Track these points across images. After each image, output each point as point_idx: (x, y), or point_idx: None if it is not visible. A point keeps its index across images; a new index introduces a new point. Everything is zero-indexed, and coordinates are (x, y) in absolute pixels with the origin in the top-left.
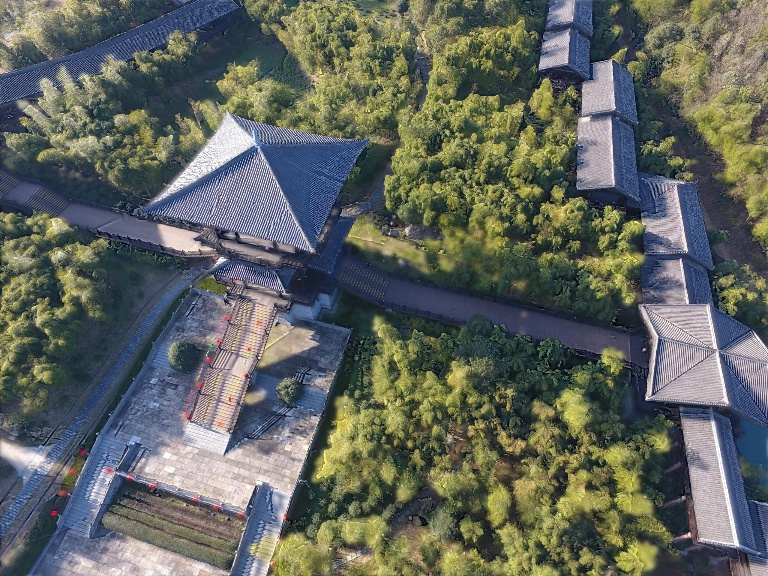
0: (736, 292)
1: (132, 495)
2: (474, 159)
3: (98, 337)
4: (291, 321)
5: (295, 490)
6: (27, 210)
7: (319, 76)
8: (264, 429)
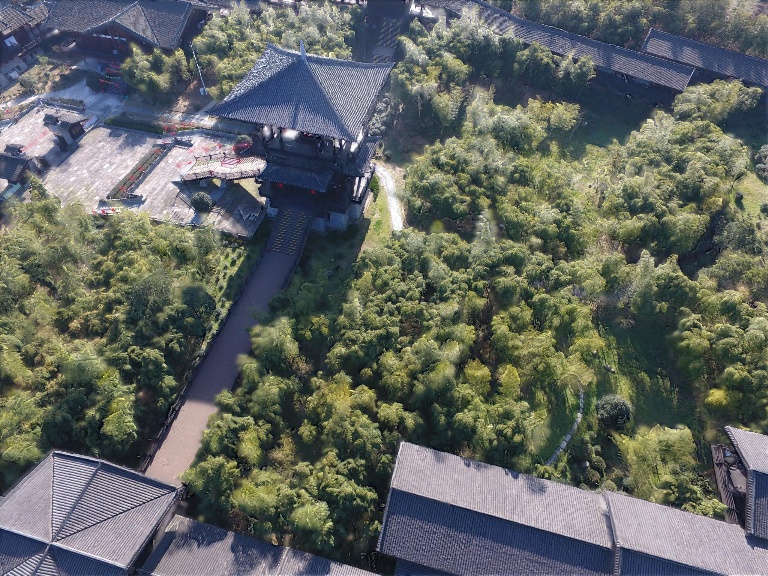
0: None
1: None
2: (438, 301)
3: None
4: None
5: None
6: (370, 57)
7: (574, 162)
8: (183, 198)
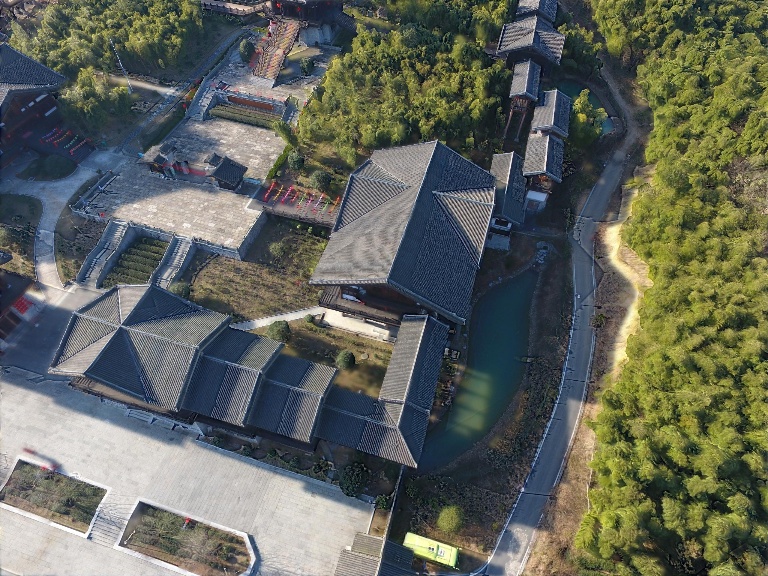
0: (566, 31)
1: (223, 104)
2: None
3: (196, 50)
4: (307, 44)
5: (310, 99)
6: None
7: None
8: (293, 82)
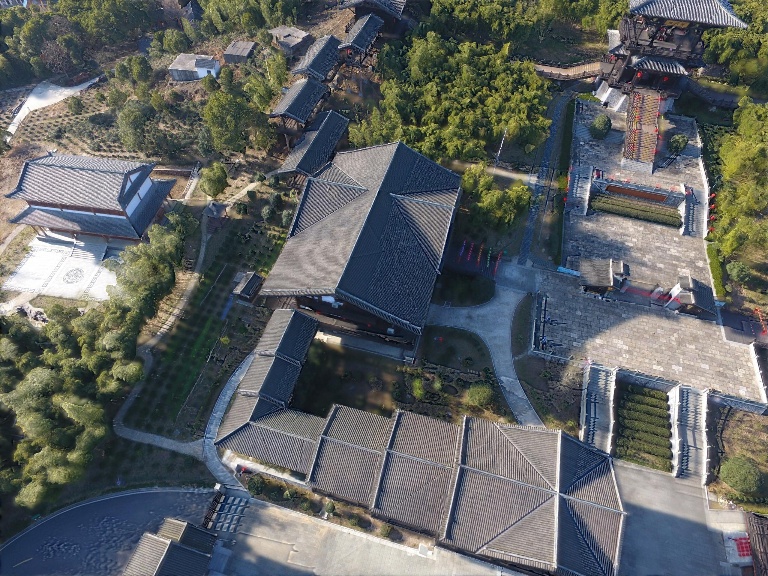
0: None
1: (602, 195)
2: (750, 19)
3: None
4: None
5: None
6: None
7: None
8: (668, 164)
